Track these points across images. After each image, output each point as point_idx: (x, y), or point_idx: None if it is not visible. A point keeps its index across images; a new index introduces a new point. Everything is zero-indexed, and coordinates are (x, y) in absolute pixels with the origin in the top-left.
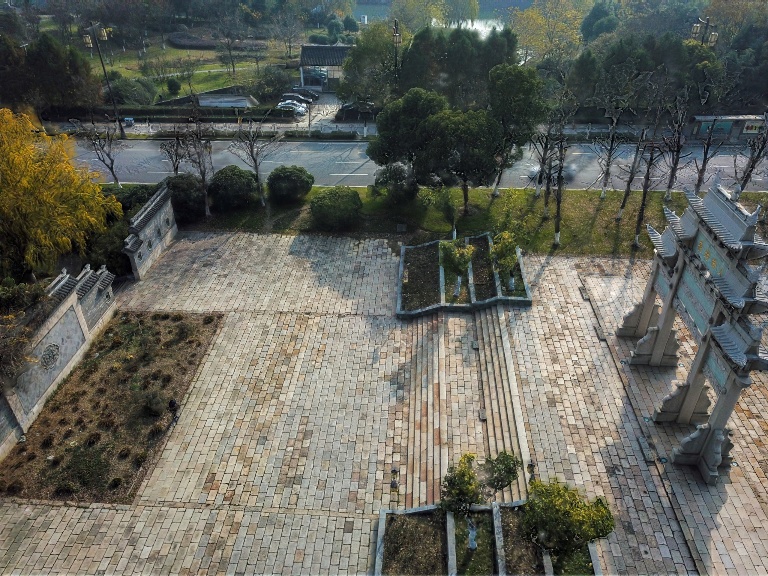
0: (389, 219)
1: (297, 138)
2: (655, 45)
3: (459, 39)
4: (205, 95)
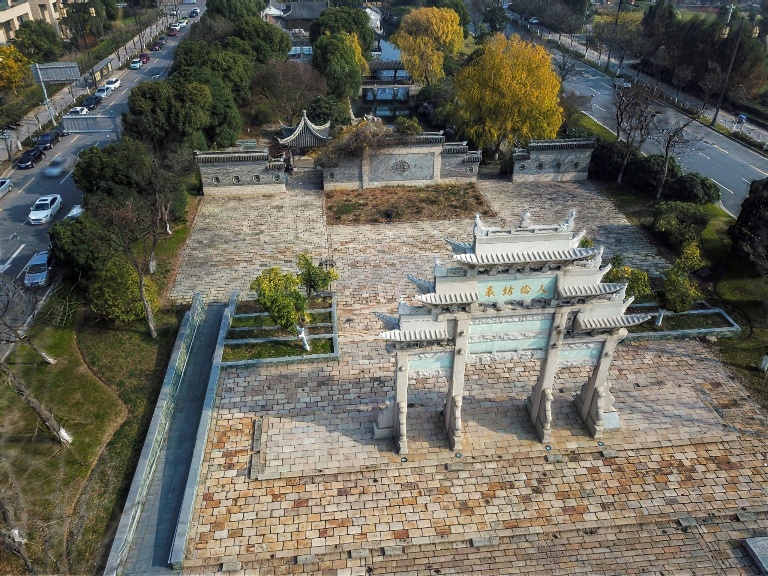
0: (710, 261)
1: None
2: None
3: None
4: None
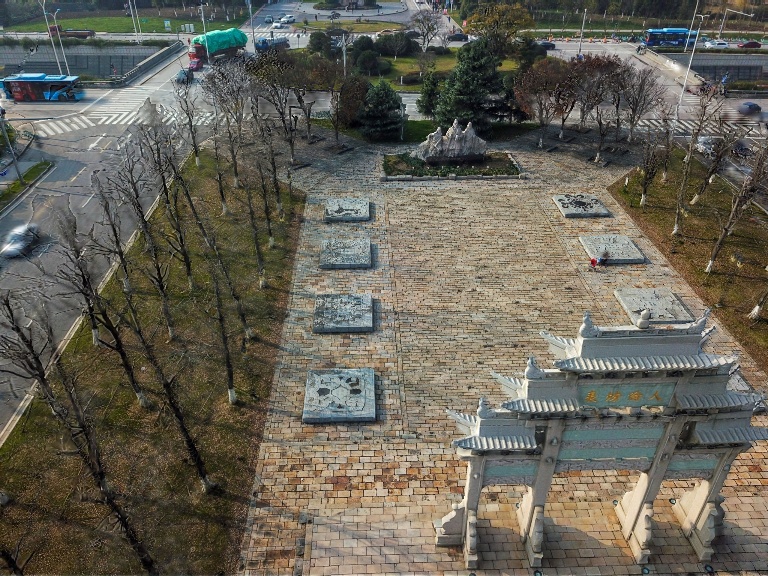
0: None
1: None
2: None
3: None
4: None
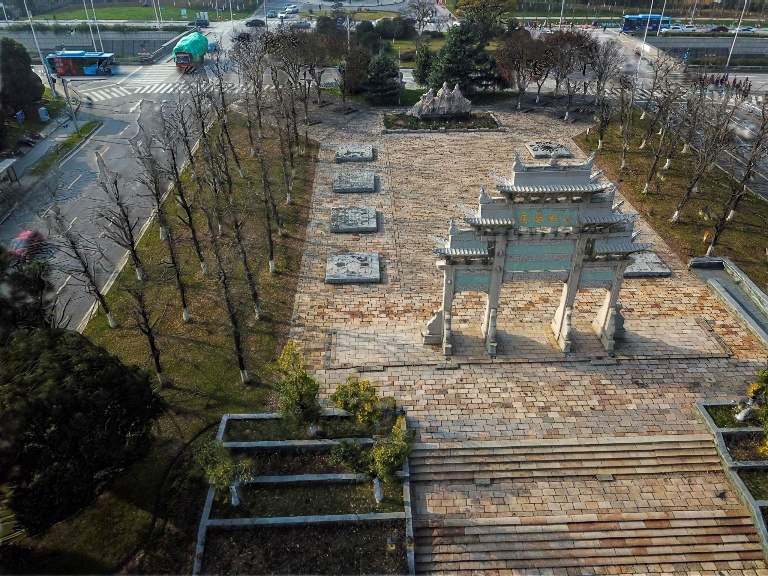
0: None
1: None
2: None
3: None
4: None
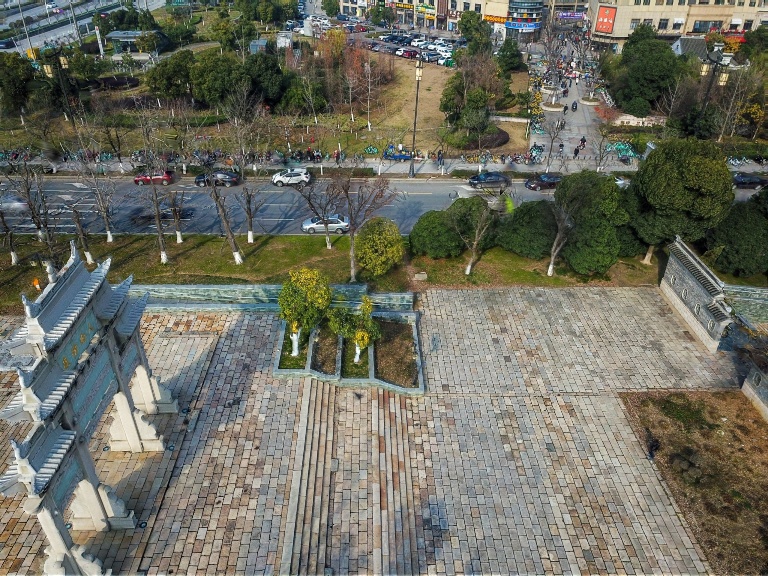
0: None
1: None
2: None
3: None
4: None
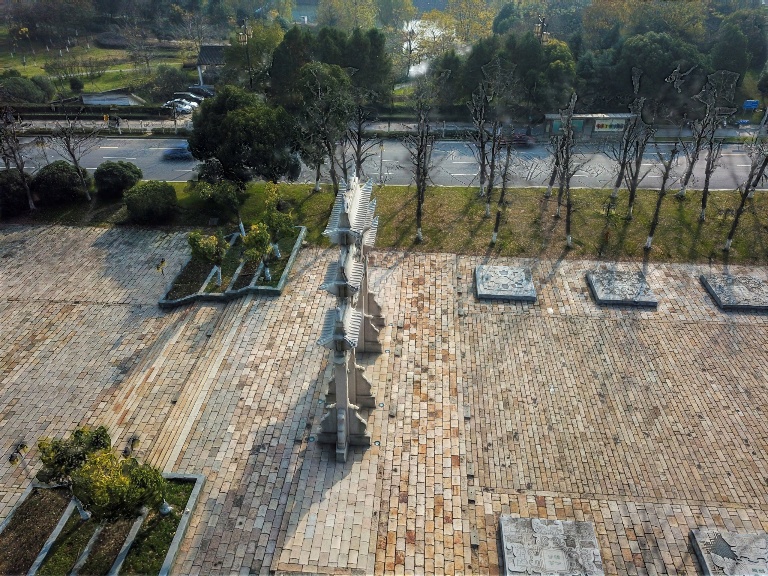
0: (204, 213)
1: (163, 135)
2: (516, 45)
3: (323, 38)
4: (87, 93)
